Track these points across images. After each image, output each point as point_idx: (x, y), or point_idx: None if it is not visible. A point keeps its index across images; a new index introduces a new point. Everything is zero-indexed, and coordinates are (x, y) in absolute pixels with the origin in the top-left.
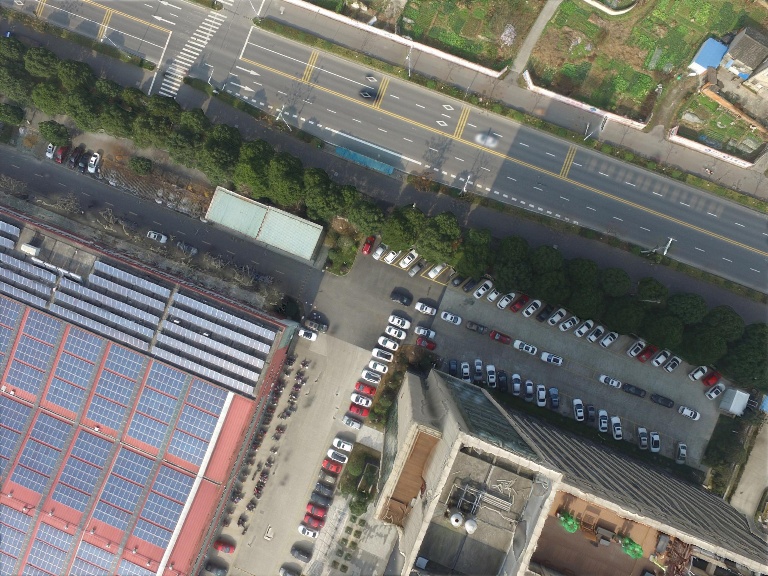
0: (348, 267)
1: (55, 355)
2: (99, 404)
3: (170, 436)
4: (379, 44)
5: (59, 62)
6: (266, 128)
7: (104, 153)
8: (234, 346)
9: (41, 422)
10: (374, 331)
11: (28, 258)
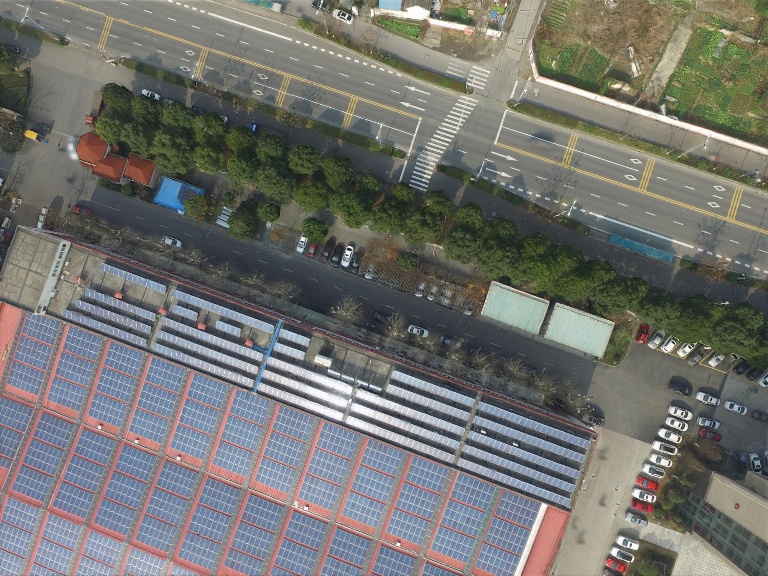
0: (622, 357)
1: (352, 469)
2: (400, 518)
3: (478, 550)
4: (642, 124)
5: (325, 159)
6: (526, 215)
7: (356, 245)
8: (545, 456)
9: (339, 538)
10: (652, 423)
11: (318, 369)
